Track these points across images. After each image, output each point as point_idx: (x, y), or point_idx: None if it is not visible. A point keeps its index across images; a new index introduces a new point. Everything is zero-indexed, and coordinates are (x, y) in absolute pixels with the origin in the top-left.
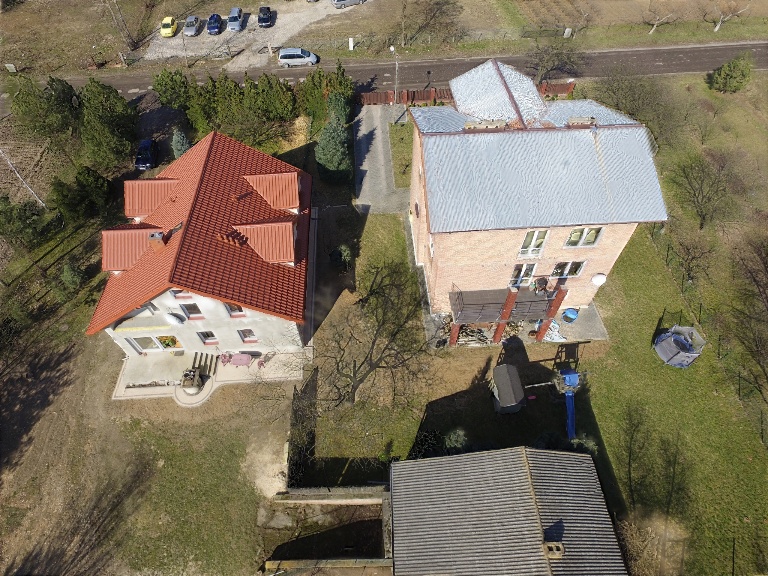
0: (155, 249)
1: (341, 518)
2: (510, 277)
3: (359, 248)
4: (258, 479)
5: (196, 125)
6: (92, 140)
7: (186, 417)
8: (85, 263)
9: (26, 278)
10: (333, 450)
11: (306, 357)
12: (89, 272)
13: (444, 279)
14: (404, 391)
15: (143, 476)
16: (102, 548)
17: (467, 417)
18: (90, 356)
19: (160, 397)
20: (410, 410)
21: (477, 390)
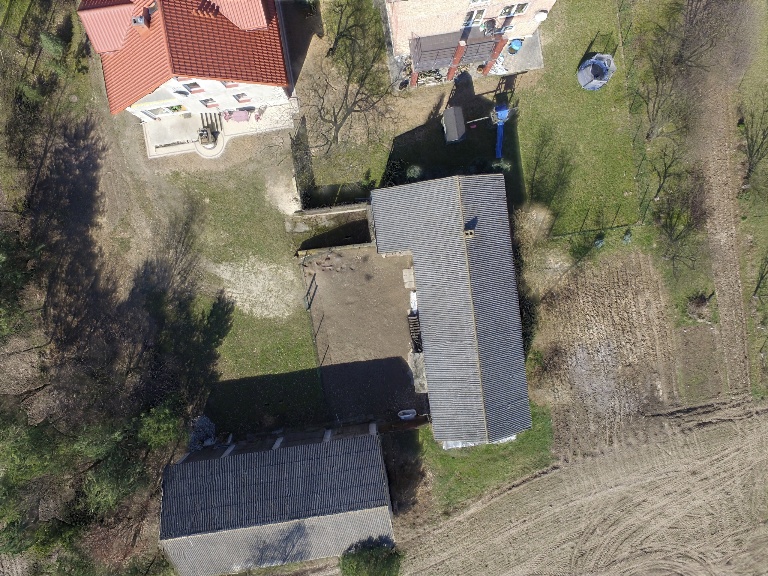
0: (140, 33)
1: (340, 221)
2: (463, 22)
3: None
4: (279, 204)
5: None
6: None
7: (212, 166)
8: (52, 24)
9: (4, 48)
10: (328, 180)
11: (293, 107)
12: (62, 35)
13: (404, 30)
14: (376, 130)
15: (198, 210)
16: (191, 254)
17: (424, 146)
18: (111, 123)
19: (186, 153)
20: (381, 145)
21: (432, 124)
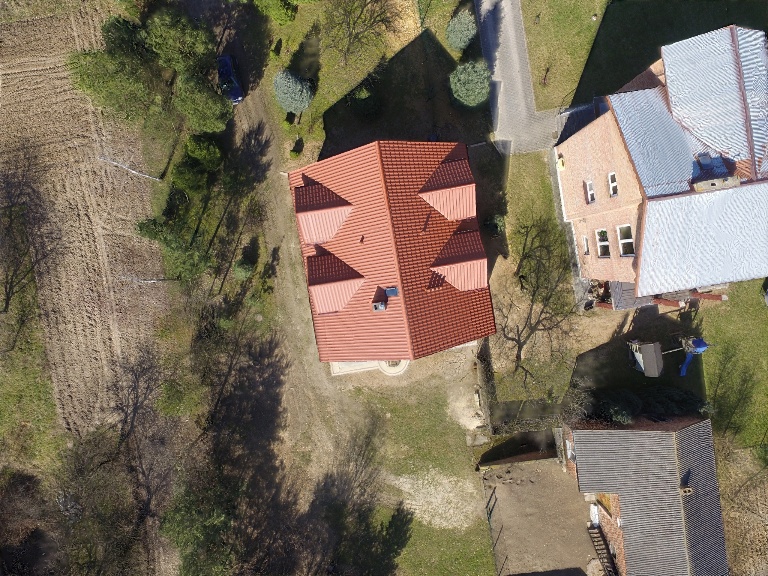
0: None
1: None
2: None
3: (506, 203)
4: (461, 419)
5: (267, 11)
6: (195, 114)
7: (395, 382)
8: (239, 246)
9: None
10: (510, 396)
11: None
12: (249, 257)
13: None
14: (559, 348)
15: (379, 424)
16: (371, 467)
17: (607, 364)
18: (294, 340)
19: (369, 370)
20: (565, 363)
21: (616, 342)
